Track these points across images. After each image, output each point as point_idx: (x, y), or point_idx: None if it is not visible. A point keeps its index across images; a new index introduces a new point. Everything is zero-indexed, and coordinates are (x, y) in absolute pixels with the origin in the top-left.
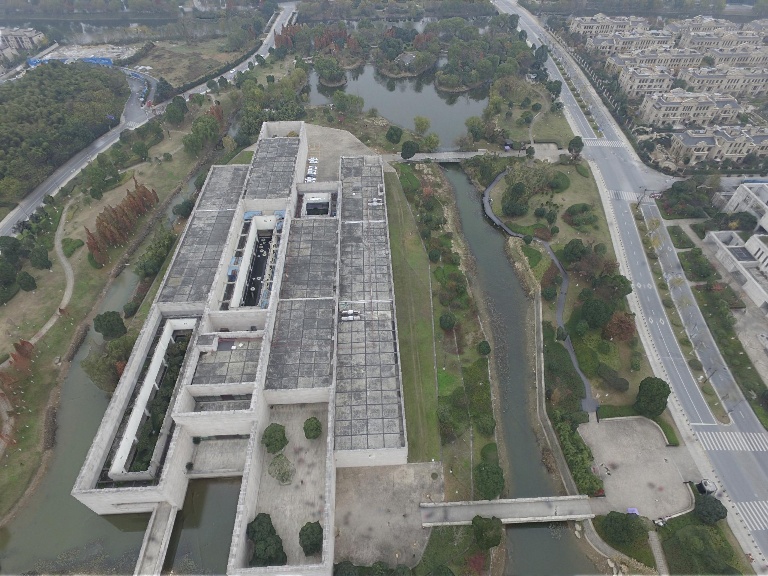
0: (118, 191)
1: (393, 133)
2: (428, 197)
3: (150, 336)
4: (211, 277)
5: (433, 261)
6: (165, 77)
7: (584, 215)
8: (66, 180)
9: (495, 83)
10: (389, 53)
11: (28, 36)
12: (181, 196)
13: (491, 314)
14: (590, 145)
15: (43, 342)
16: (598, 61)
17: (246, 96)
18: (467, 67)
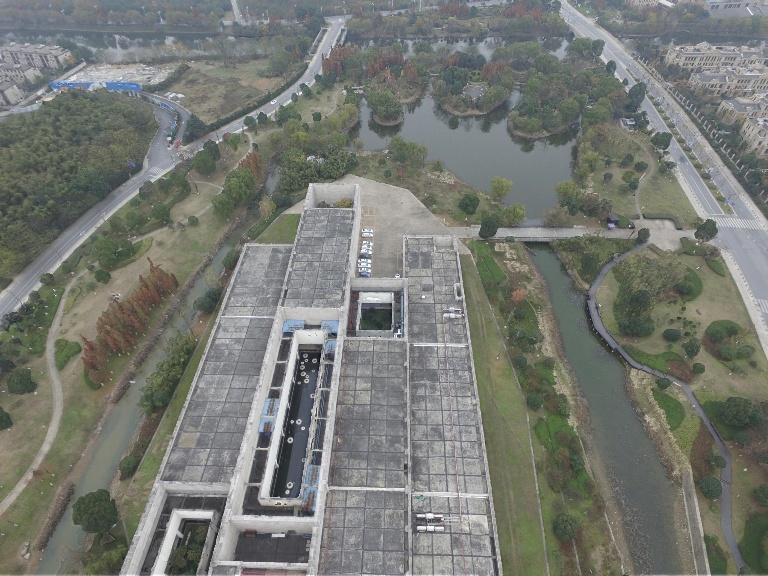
0: (130, 269)
1: (469, 203)
2: (518, 301)
3: (147, 537)
4: (236, 435)
5: (532, 408)
6: (198, 108)
7: (732, 341)
8: (72, 247)
9: (587, 132)
10: (455, 87)
11: (53, 55)
12: (205, 283)
13: (622, 509)
14: (718, 225)
15: (8, 522)
16: (707, 103)
17: (289, 141)
18: (548, 107)
